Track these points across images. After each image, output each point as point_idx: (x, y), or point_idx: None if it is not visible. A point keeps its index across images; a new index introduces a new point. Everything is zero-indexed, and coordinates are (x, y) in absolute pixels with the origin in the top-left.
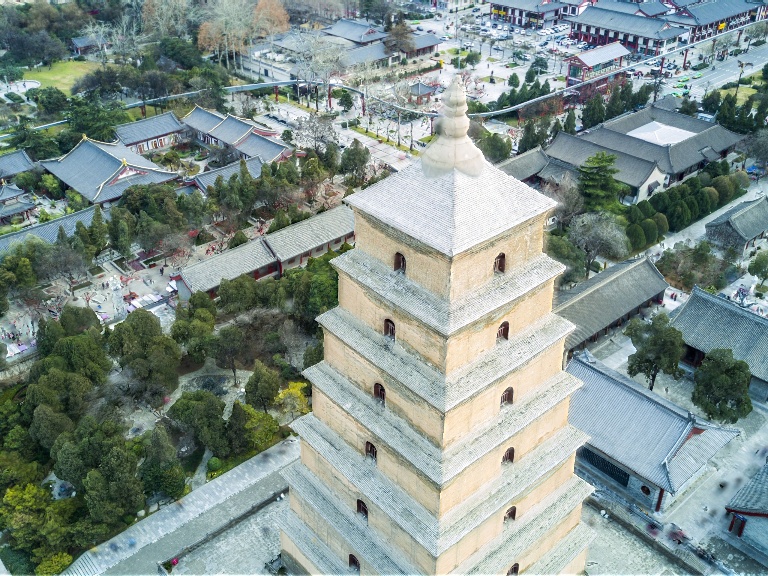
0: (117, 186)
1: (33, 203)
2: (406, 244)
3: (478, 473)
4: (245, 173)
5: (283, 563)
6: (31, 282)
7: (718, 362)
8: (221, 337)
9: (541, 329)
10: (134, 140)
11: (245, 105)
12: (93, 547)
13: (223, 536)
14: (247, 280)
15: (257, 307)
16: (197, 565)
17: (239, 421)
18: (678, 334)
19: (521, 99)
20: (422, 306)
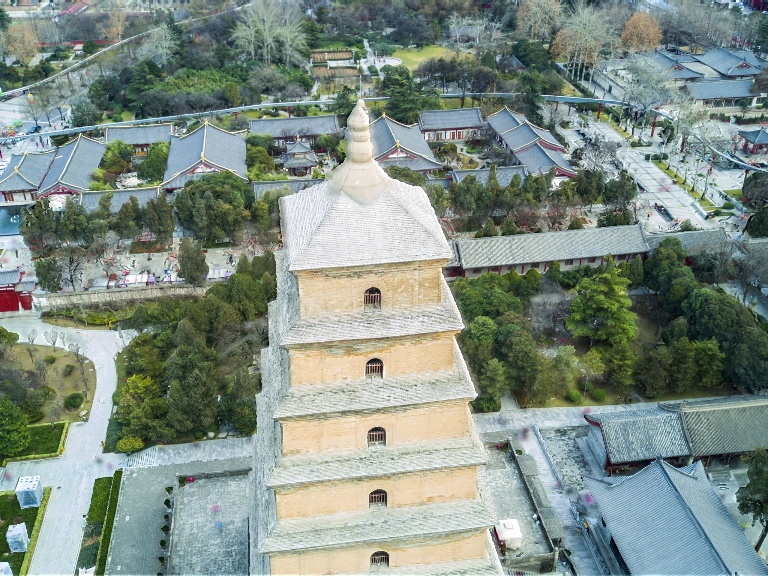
0: (385, 163)
1: (323, 162)
2: None
3: (332, 497)
4: (492, 178)
5: None
6: (264, 224)
7: None
8: None
9: (430, 382)
10: (433, 127)
11: (553, 116)
12: (163, 444)
13: (239, 478)
14: None
15: None
16: (205, 490)
17: None
18: None
19: None
20: (285, 313)
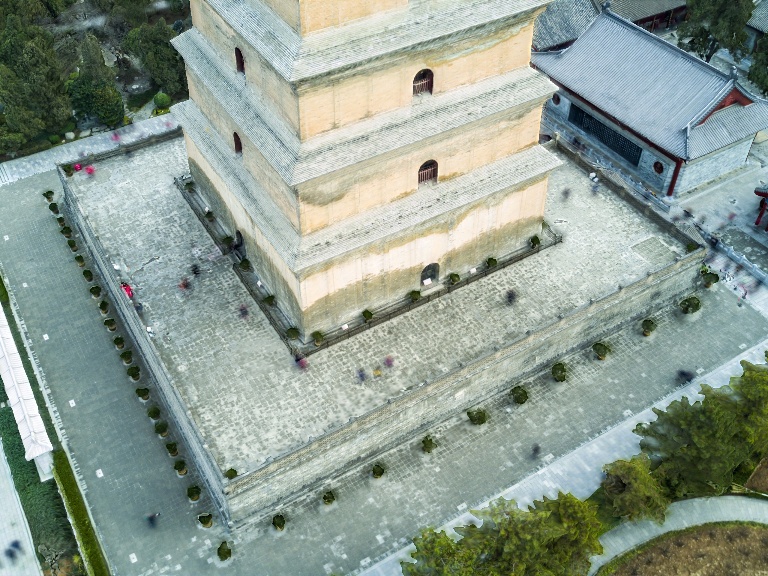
0: None
1: None
2: None
3: None
4: None
5: (192, 177)
6: None
7: None
8: None
9: None
10: None
11: None
12: (11, 159)
13: (139, 152)
14: None
15: None
16: (101, 173)
17: None
18: None
19: None
20: None
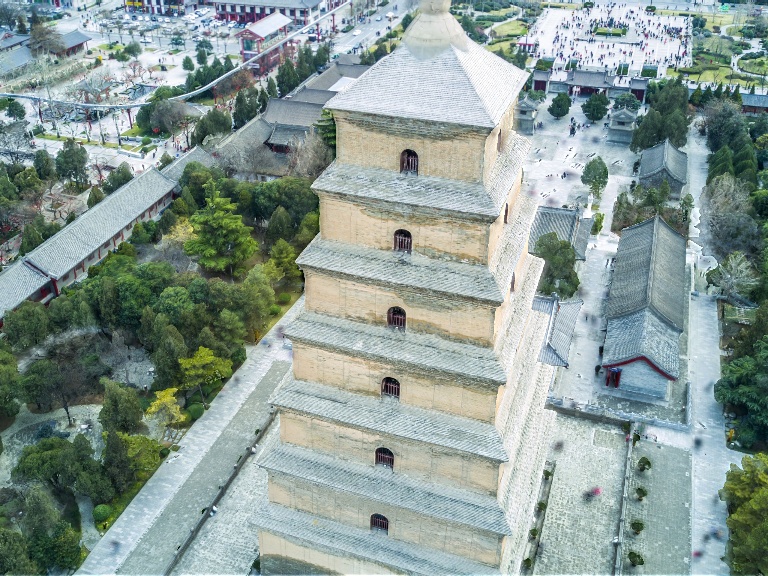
0: None
1: None
2: (420, 136)
3: None
4: None
5: (264, 571)
6: None
7: (548, 246)
8: (36, 375)
9: (521, 209)
10: None
11: None
12: None
13: None
14: (33, 306)
15: (57, 333)
16: None
17: (119, 452)
18: None
19: (211, 77)
20: (454, 197)
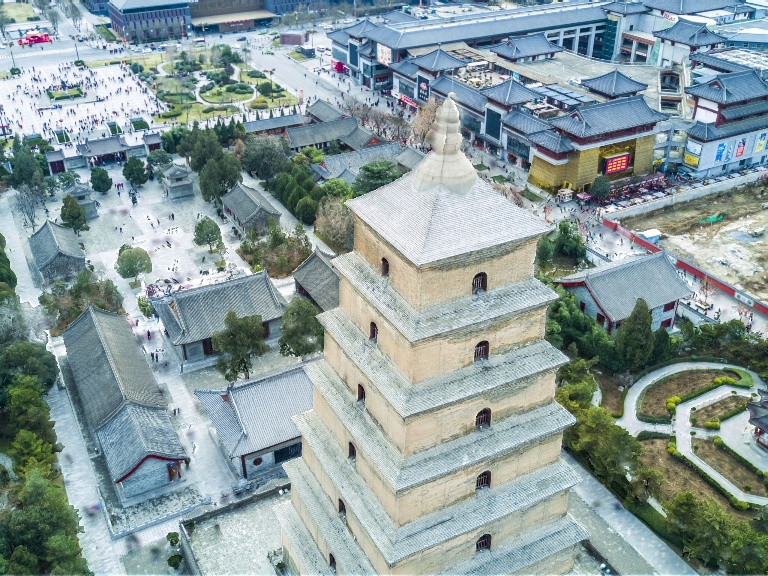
0: None
1: None
2: None
3: None
4: None
5: None
6: None
7: (299, 311)
8: None
9: None
10: None
11: None
12: None
13: None
14: None
15: None
16: None
17: None
18: (258, 316)
19: None
20: (524, 296)
